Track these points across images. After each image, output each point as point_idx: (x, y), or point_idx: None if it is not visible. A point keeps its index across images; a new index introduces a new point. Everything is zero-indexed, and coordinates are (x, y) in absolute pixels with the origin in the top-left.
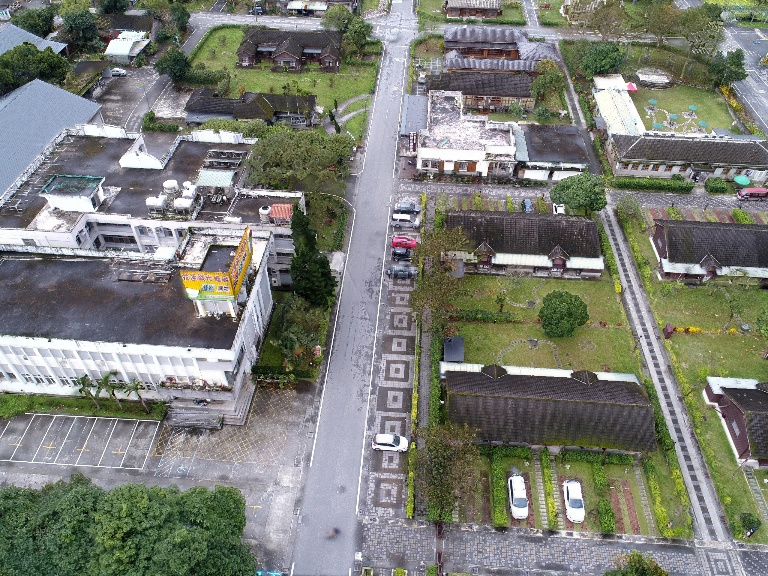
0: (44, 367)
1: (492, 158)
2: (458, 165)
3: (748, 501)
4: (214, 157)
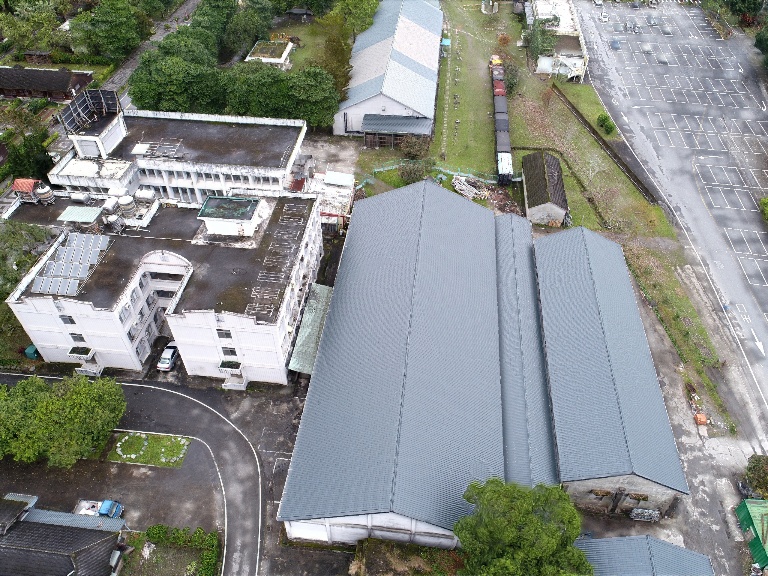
0: None
1: None
2: None
3: None
4: None
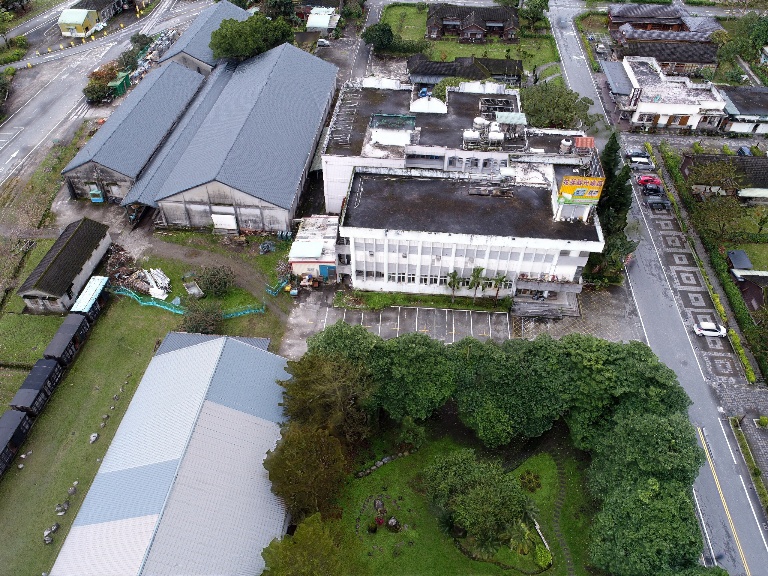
0: (414, 265)
1: (704, 112)
2: (672, 119)
3: None
4: (485, 104)
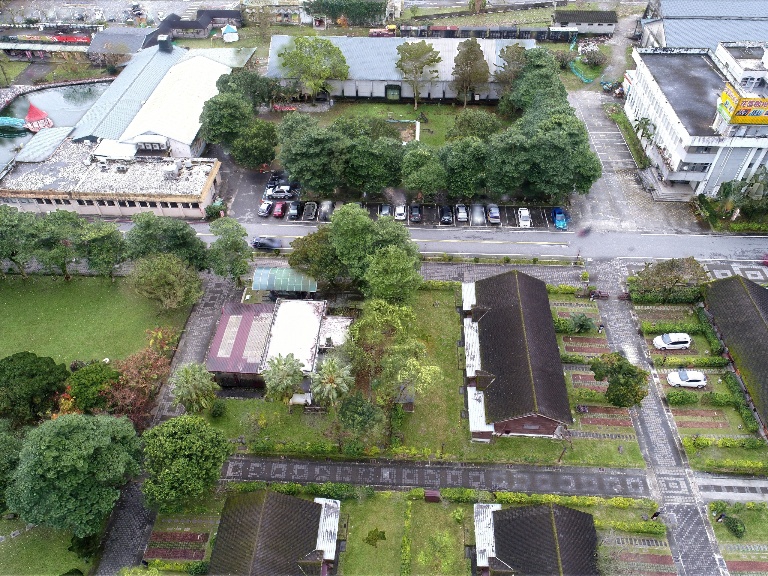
0: None
1: None
2: None
3: (761, 535)
4: None
